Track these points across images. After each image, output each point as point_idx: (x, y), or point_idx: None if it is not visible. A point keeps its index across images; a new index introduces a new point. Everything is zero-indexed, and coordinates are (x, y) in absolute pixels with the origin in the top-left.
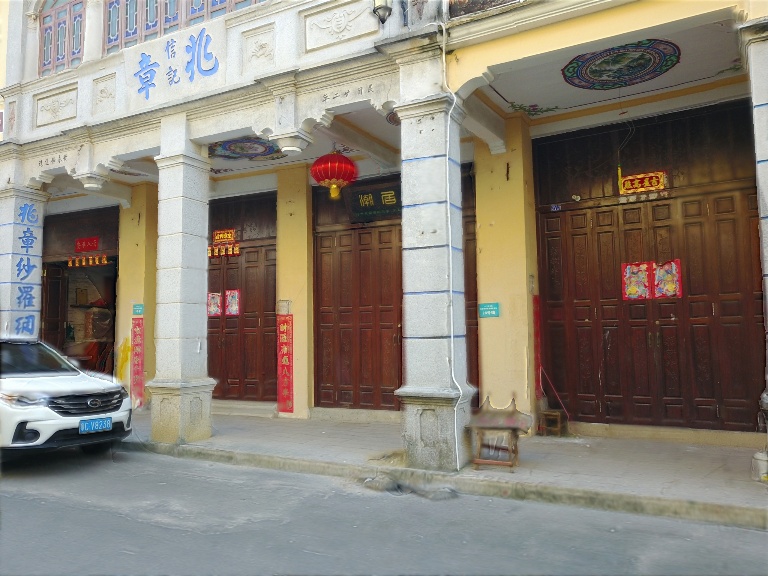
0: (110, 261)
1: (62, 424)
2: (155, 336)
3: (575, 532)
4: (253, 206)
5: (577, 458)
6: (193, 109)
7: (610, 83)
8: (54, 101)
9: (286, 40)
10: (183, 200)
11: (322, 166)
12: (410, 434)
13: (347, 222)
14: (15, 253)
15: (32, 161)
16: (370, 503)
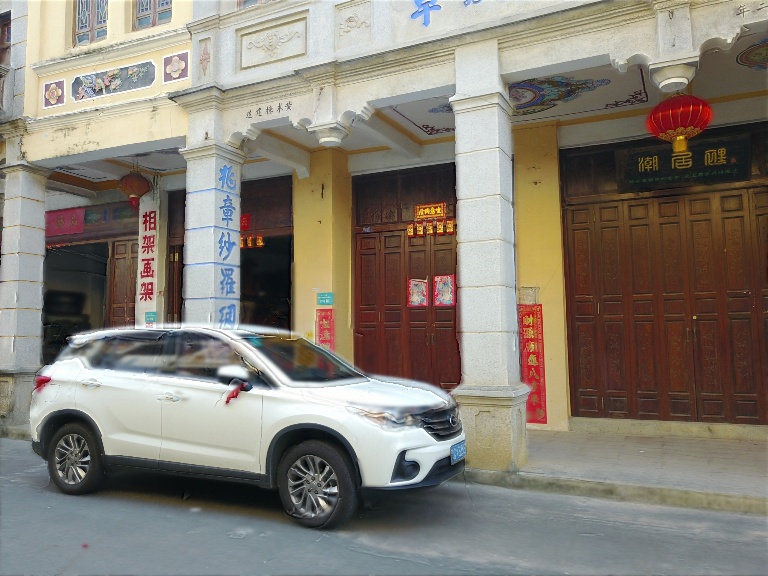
0: None
1: (440, 452)
2: (459, 329)
3: None
4: None
5: None
6: (512, 34)
7: None
8: (271, 35)
9: None
10: (500, 152)
11: (680, 109)
12: None
13: (612, 192)
14: (217, 226)
15: (235, 112)
16: None
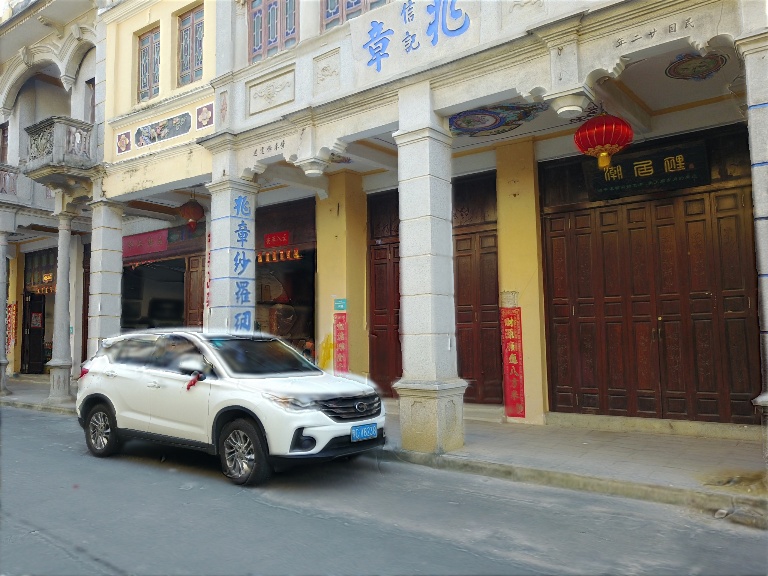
0: (300, 255)
1: (336, 431)
2: (400, 332)
3: None
4: (464, 189)
5: None
6: (439, 75)
7: None
8: (269, 86)
9: None
10: (430, 179)
11: (594, 130)
12: None
13: (585, 200)
14: (232, 247)
15: (246, 151)
16: (765, 548)
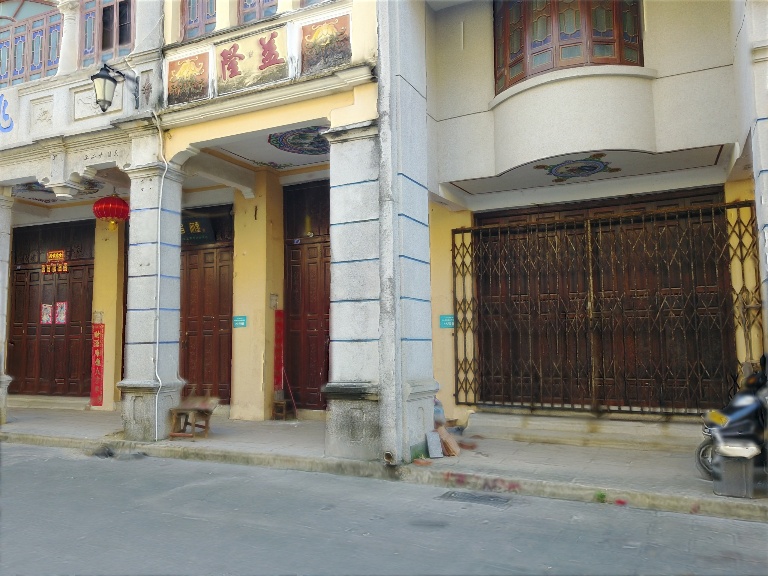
0: None
1: None
2: None
3: (182, 474)
4: (80, 231)
5: (266, 433)
6: None
7: (315, 151)
8: None
9: (60, 110)
10: None
11: (98, 207)
12: (127, 415)
13: None
14: None
15: None
16: (74, 463)
